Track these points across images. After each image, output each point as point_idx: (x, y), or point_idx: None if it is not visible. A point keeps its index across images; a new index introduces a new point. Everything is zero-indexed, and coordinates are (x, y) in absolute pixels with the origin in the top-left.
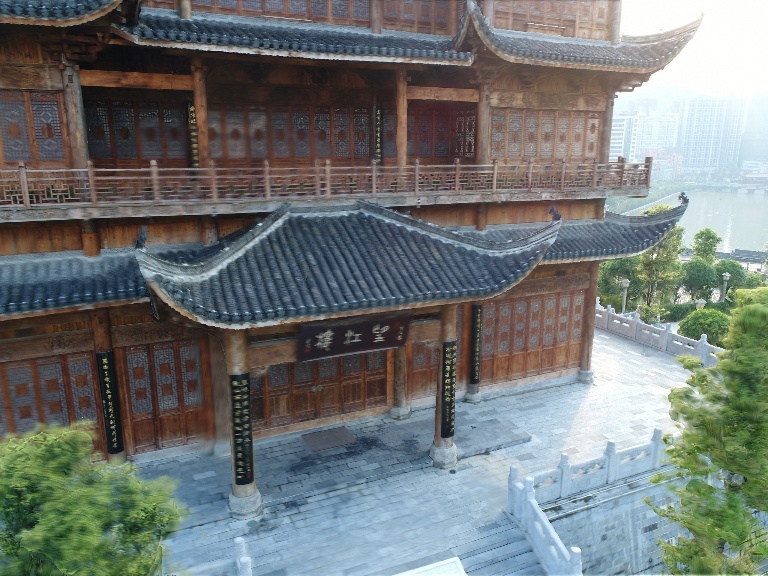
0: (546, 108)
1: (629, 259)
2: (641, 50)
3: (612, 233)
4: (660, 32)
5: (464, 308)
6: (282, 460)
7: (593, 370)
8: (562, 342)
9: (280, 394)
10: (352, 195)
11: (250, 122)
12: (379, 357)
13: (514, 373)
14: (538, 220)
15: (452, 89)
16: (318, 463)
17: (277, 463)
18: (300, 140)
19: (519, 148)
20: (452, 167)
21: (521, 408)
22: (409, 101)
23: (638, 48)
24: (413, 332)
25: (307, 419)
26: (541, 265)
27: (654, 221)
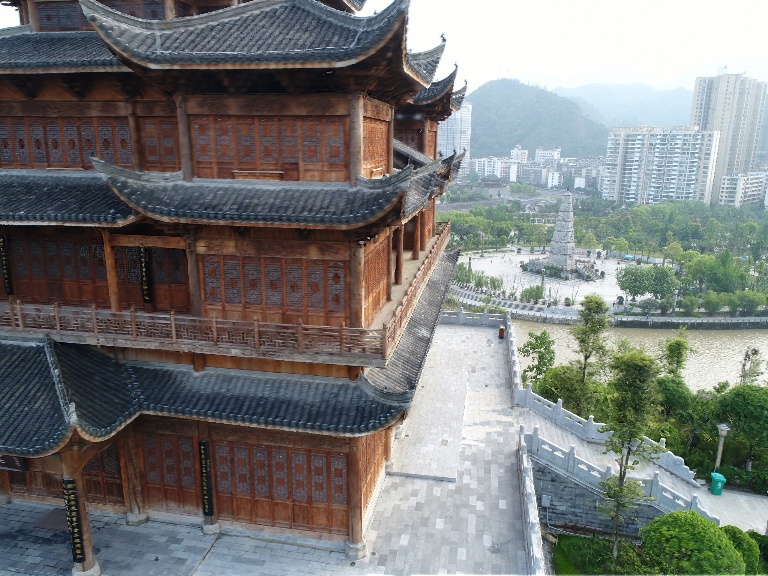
0: (266, 256)
1: (746, 397)
2: (364, 198)
3: (348, 401)
4: (383, 178)
5: (193, 440)
6: (8, 525)
7: (362, 545)
8: (320, 503)
9: (36, 471)
10: (40, 330)
11: (45, 250)
12: (114, 464)
13: (260, 518)
14: (269, 370)
15: (157, 237)
16: (18, 539)
17: (2, 526)
18: (83, 265)
19: (239, 295)
20: (127, 314)
21: (237, 558)
22: (115, 247)
23: (364, 195)
24: (38, 462)
25: (59, 497)
26: (220, 423)
27: (389, 400)
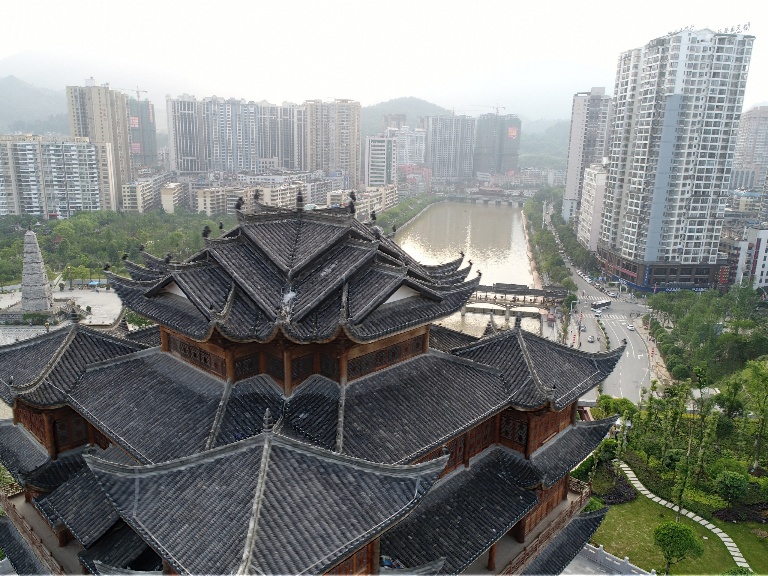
0: None
1: None
2: (589, 431)
3: (573, 528)
4: (597, 420)
5: None
6: None
7: None
8: None
9: None
10: None
11: None
12: None
13: None
14: None
15: None
16: None
17: None
18: None
19: (536, 506)
20: None
21: None
22: None
23: (587, 429)
24: None
25: None
26: None
27: (593, 515)
